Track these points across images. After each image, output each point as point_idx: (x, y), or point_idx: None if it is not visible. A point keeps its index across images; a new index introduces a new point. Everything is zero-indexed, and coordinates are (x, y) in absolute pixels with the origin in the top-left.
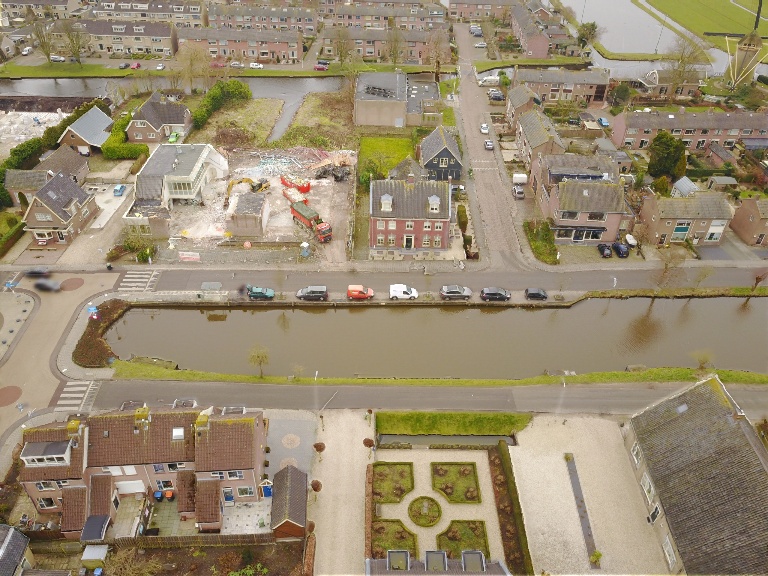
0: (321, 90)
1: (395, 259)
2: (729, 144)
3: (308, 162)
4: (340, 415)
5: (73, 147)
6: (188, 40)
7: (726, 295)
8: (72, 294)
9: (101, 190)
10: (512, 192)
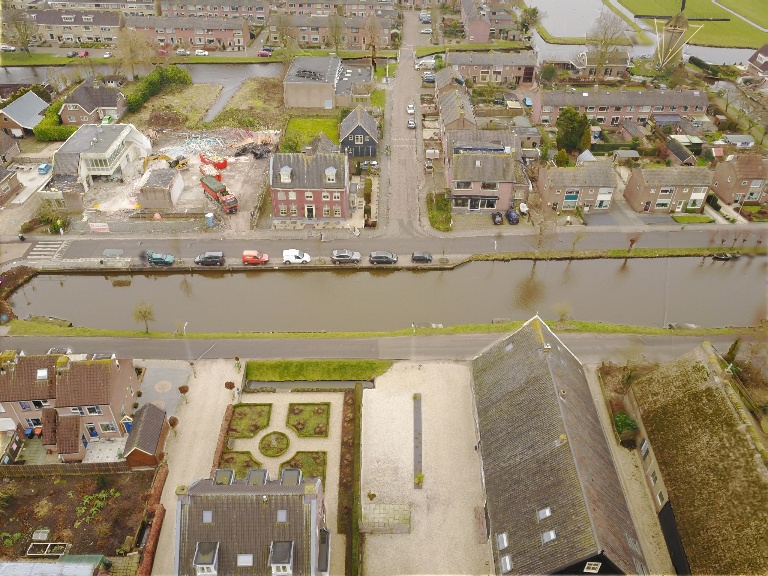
0: (265, 76)
1: (296, 228)
2: (642, 120)
3: (232, 141)
4: (214, 364)
5: (7, 130)
6: (136, 29)
7: (603, 257)
8: None
9: (27, 169)
10: (424, 167)
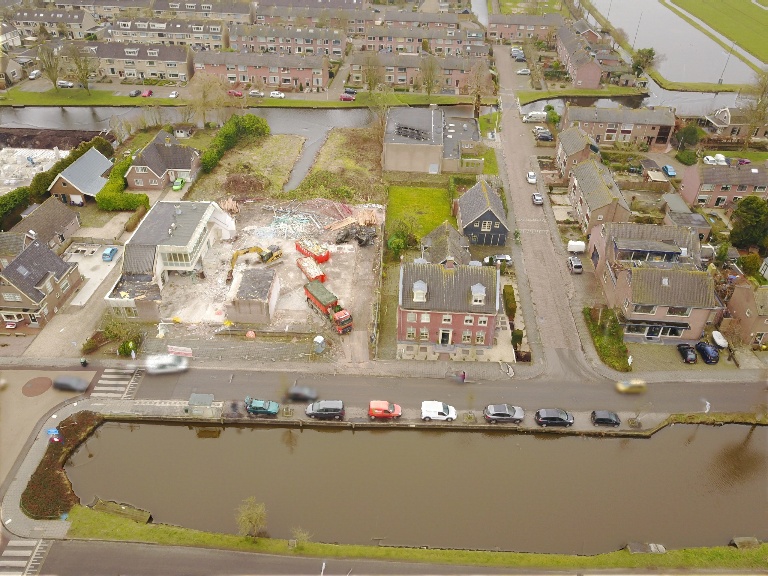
0: (347, 122)
1: (428, 359)
2: None
3: (328, 219)
4: None
5: (65, 196)
6: (205, 65)
7: None
8: (35, 401)
9: (89, 253)
10: (567, 263)
